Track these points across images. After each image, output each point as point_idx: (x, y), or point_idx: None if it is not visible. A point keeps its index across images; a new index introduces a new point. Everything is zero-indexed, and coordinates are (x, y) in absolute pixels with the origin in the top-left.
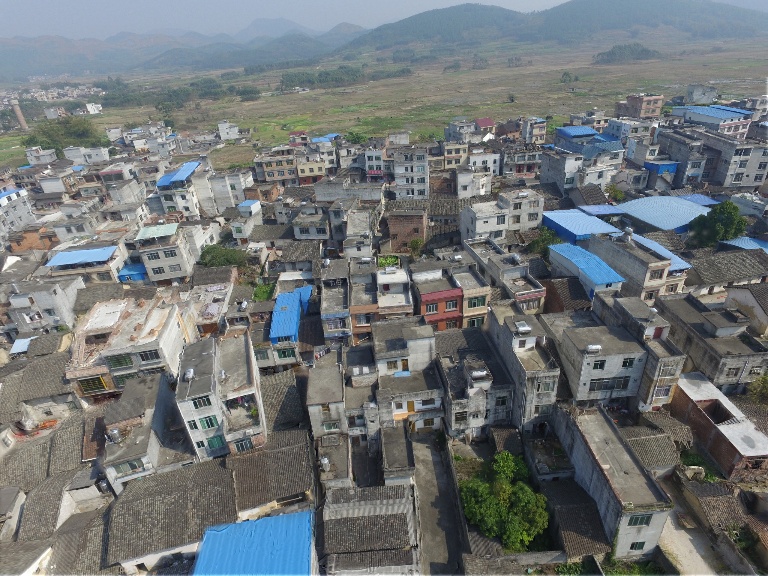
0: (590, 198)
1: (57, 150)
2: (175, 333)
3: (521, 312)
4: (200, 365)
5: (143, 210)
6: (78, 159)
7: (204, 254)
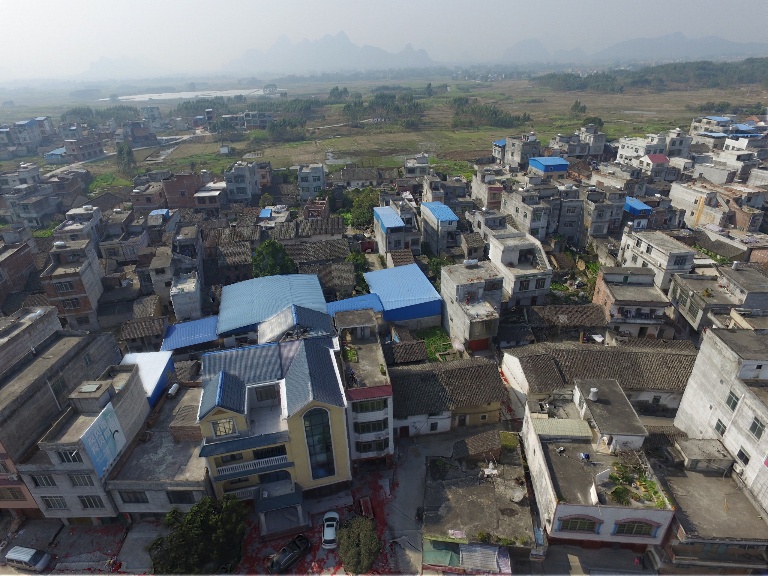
0: None
1: None
2: (689, 199)
3: None
4: None
5: None
6: None
7: None
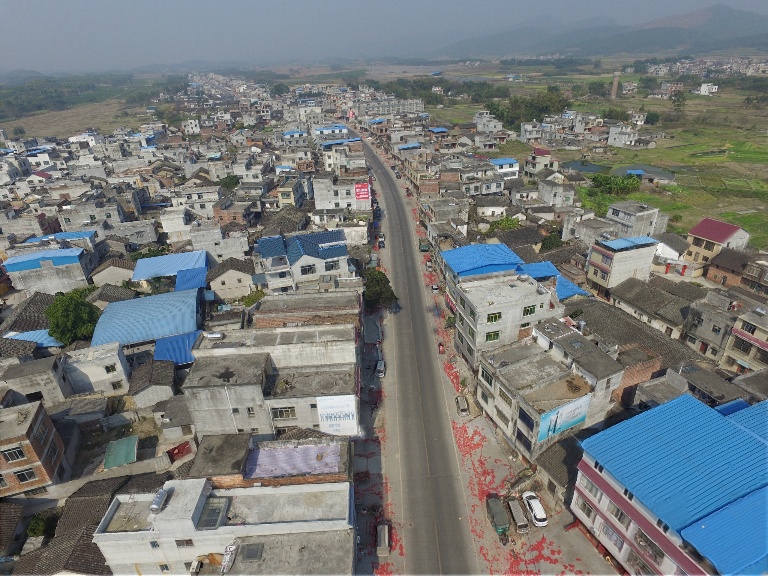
0: (214, 270)
1: (497, 117)
2: None
3: (25, 219)
4: (64, 178)
5: (307, 155)
6: (480, 126)
7: (226, 177)
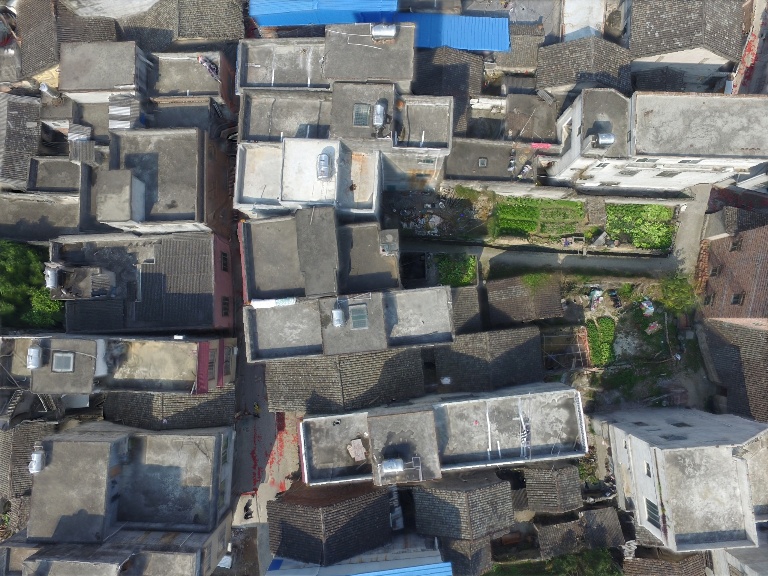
0: None
1: None
2: None
3: (160, 390)
4: None
5: None
6: None
7: None
